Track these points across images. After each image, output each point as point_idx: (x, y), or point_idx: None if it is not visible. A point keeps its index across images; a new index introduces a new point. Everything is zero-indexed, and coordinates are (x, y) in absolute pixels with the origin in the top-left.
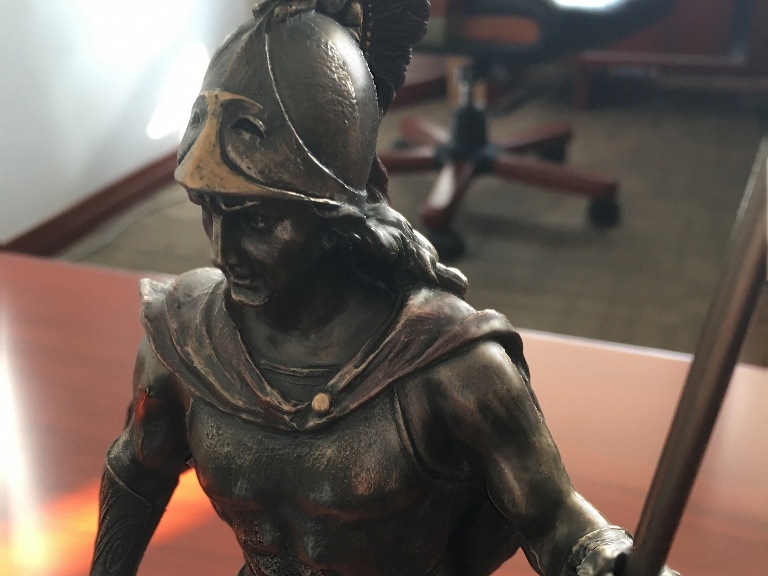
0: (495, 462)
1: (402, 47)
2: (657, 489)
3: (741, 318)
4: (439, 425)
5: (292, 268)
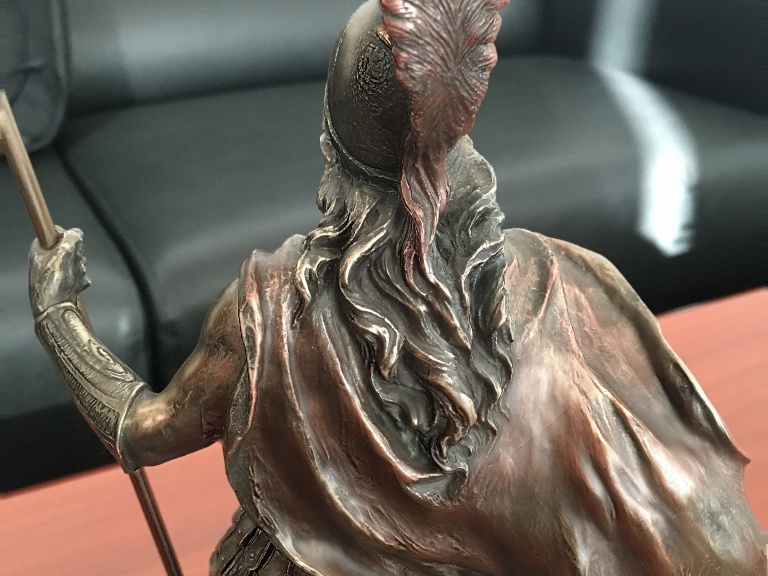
0: None
1: None
2: None
3: None
4: None
5: None
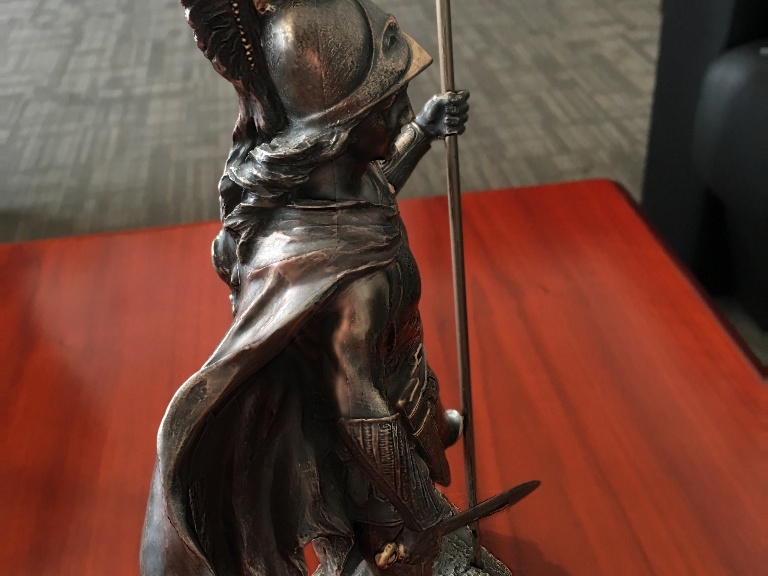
0: None
1: None
2: None
3: None
4: None
5: None
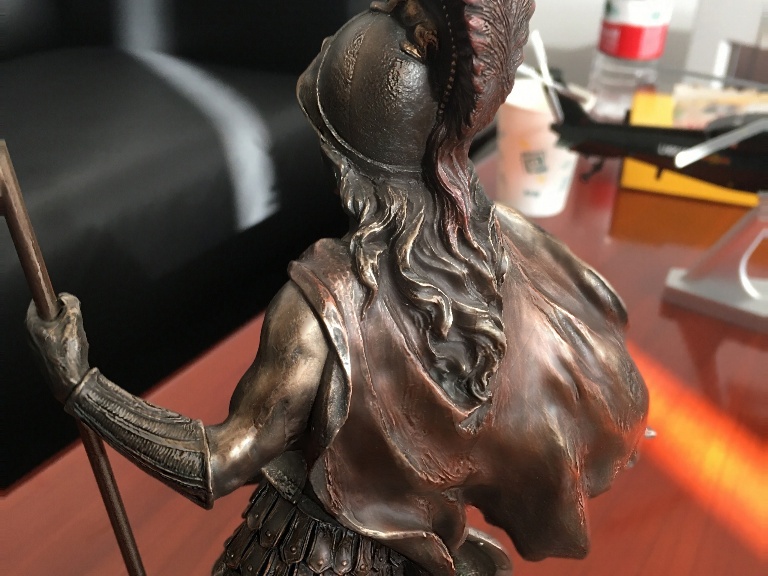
0: None
1: (472, 90)
2: None
3: None
4: None
5: None
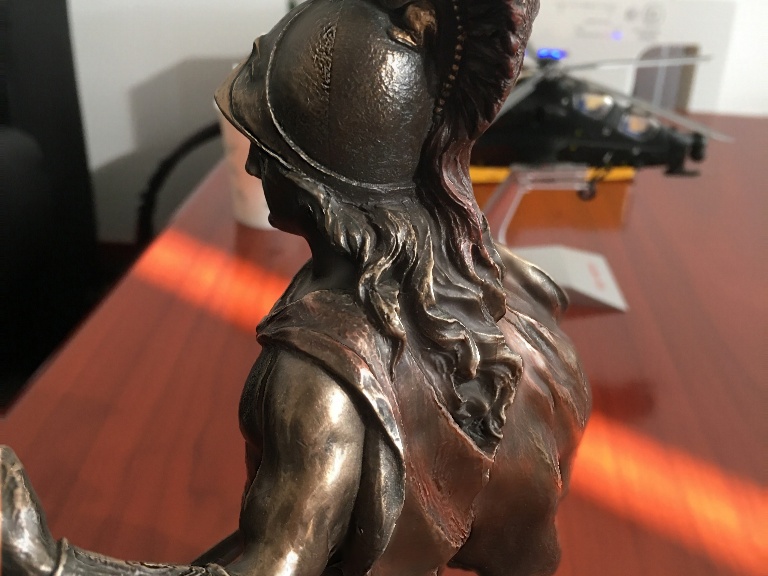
0: None
1: (495, 76)
2: None
3: None
4: None
5: (276, 203)
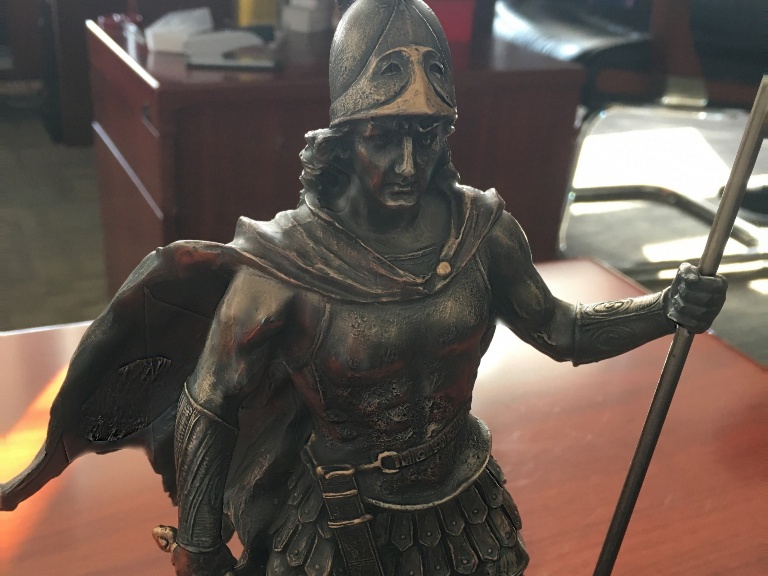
0: (524, 282)
1: None
2: (721, 219)
3: (764, 119)
4: (495, 267)
5: None
